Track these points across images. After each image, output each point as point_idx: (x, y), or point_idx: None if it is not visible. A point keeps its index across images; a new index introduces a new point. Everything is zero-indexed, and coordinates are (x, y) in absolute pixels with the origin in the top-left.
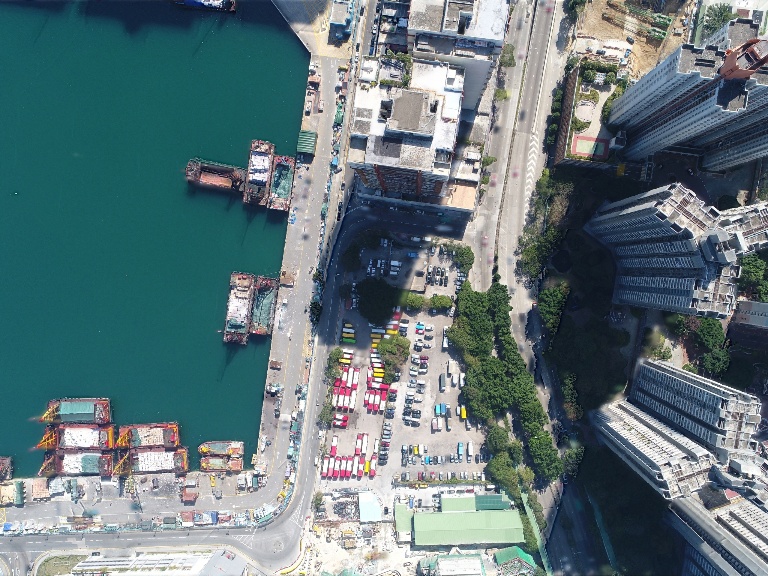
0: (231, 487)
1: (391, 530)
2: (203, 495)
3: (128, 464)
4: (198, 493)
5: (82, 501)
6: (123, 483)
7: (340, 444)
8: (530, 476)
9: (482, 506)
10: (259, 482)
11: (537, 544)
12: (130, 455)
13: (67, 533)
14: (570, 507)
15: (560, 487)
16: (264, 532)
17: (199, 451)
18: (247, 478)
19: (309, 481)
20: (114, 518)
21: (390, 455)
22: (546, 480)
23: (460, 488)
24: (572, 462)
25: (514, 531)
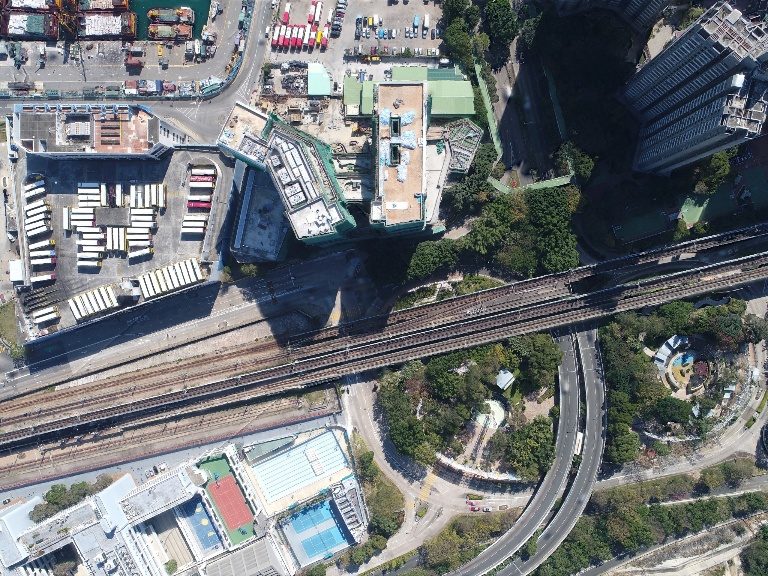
0: (178, 57)
1: (339, 107)
2: (149, 65)
3: (74, 26)
4: (144, 62)
5: (25, 67)
6: (68, 47)
7: (293, 14)
8: (485, 41)
9: (434, 79)
10: (207, 50)
11: (487, 116)
12: (77, 18)
13: (7, 99)
14: (525, 88)
15: (516, 67)
16: (209, 105)
17: (148, 16)
18: (195, 44)
19: (259, 53)
20: (56, 86)
21: (344, 27)
22: (502, 59)
23: (413, 65)
24: (529, 29)
25: (464, 100)
